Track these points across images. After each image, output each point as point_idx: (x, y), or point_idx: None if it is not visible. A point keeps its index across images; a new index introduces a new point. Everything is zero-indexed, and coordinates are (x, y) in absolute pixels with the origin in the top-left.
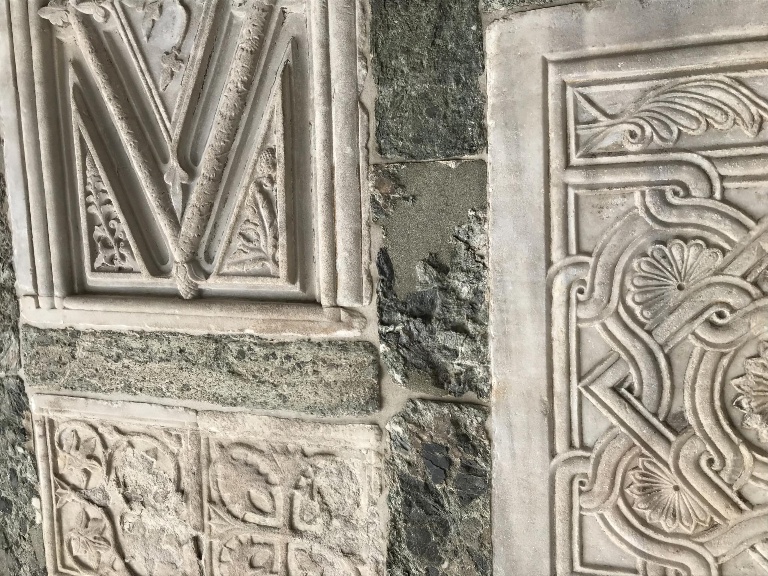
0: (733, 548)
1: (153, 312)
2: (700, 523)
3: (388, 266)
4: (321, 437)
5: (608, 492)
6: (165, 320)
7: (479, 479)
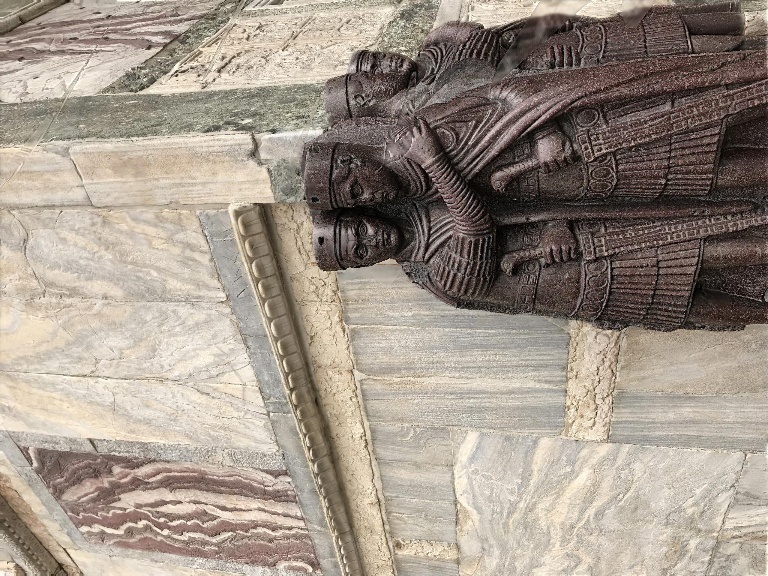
0: (528, 2)
1: (309, 2)
2: (516, 1)
3: None
4: (371, 8)
5: (484, 1)
6: (314, 2)
7: (435, 5)
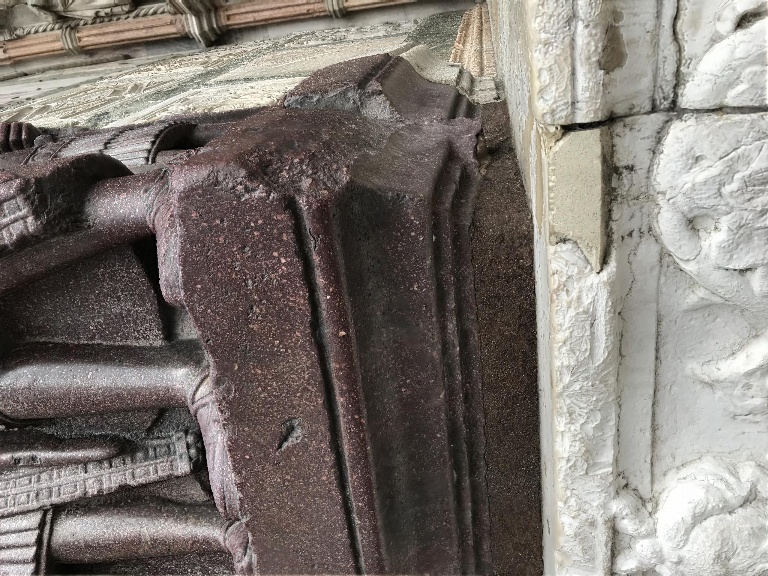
0: None
1: None
2: None
3: (107, 113)
4: None
5: None
6: None
7: None
